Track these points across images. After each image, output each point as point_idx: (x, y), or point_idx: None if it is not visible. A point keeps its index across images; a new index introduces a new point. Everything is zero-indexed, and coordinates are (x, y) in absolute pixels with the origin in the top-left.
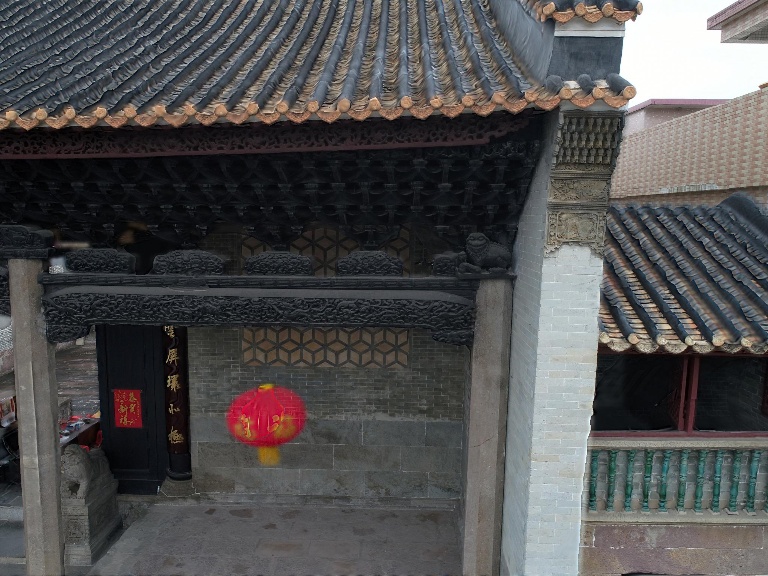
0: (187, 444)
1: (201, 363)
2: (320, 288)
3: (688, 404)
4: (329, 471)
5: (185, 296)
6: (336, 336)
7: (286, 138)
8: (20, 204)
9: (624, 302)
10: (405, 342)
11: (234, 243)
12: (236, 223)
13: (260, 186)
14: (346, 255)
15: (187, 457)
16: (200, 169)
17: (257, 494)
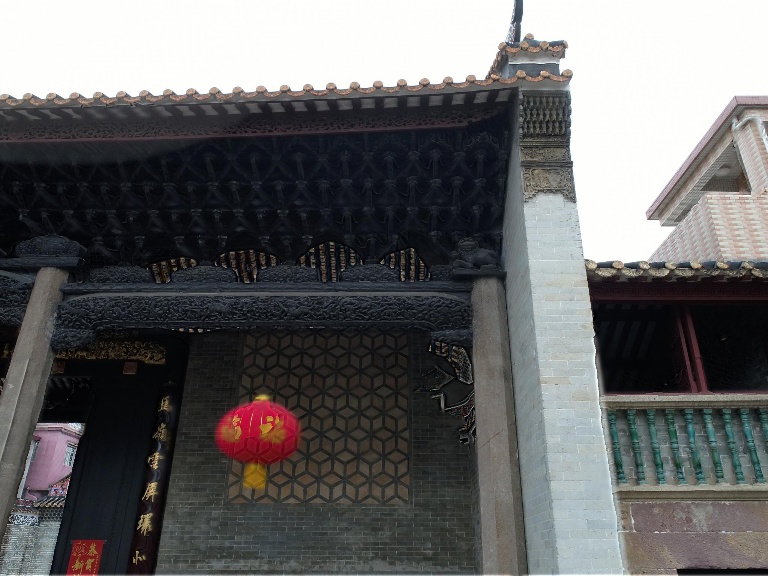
0: None
1: (180, 501)
2: (325, 291)
3: (694, 363)
4: None
5: (196, 296)
6: (331, 467)
7: (307, 124)
8: (69, 210)
9: None
10: (405, 473)
11: (235, 372)
12: (254, 233)
13: (280, 182)
14: (345, 382)
15: None
16: (233, 162)
17: None
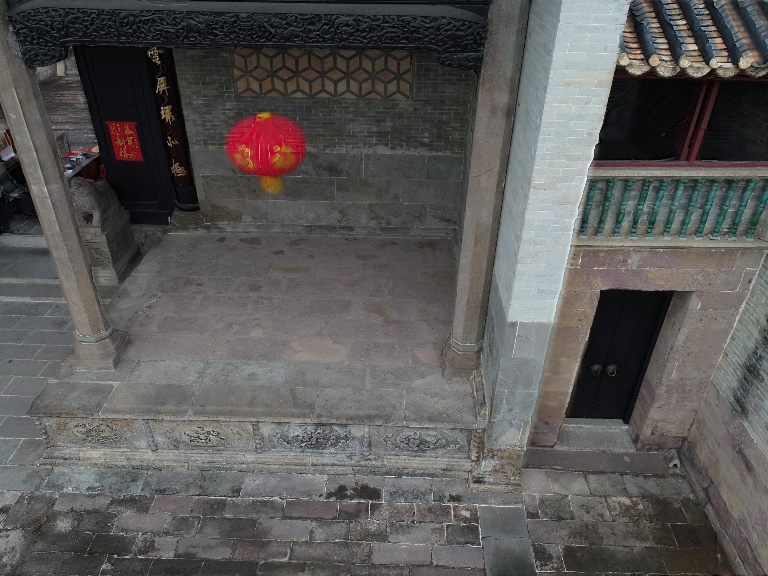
0: (190, 177)
1: (193, 93)
2: (315, 2)
3: (696, 133)
4: (332, 203)
5: (165, 11)
6: (334, 63)
7: None
8: None
9: (652, 18)
10: (408, 70)
11: None
12: None
13: None
14: None
15: (192, 189)
16: None
17: (264, 224)
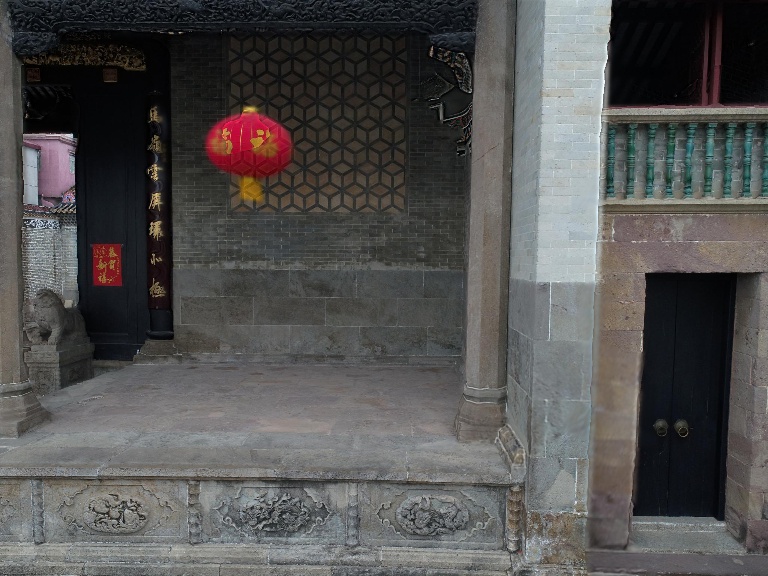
0: (169, 299)
1: (186, 210)
2: None
3: (712, 72)
4: (321, 327)
5: None
6: (329, 178)
7: None
8: None
9: None
10: (401, 184)
11: (223, 80)
12: None
13: None
14: (339, 91)
15: (169, 314)
16: None
17: (243, 354)
